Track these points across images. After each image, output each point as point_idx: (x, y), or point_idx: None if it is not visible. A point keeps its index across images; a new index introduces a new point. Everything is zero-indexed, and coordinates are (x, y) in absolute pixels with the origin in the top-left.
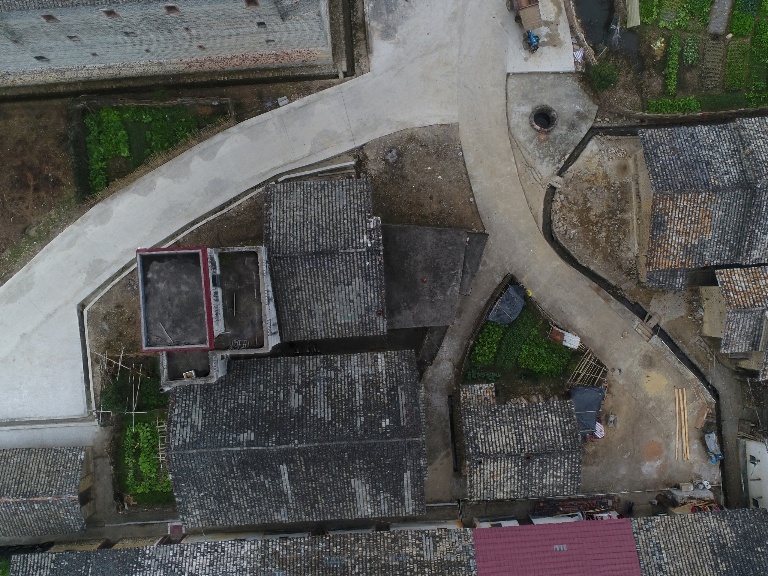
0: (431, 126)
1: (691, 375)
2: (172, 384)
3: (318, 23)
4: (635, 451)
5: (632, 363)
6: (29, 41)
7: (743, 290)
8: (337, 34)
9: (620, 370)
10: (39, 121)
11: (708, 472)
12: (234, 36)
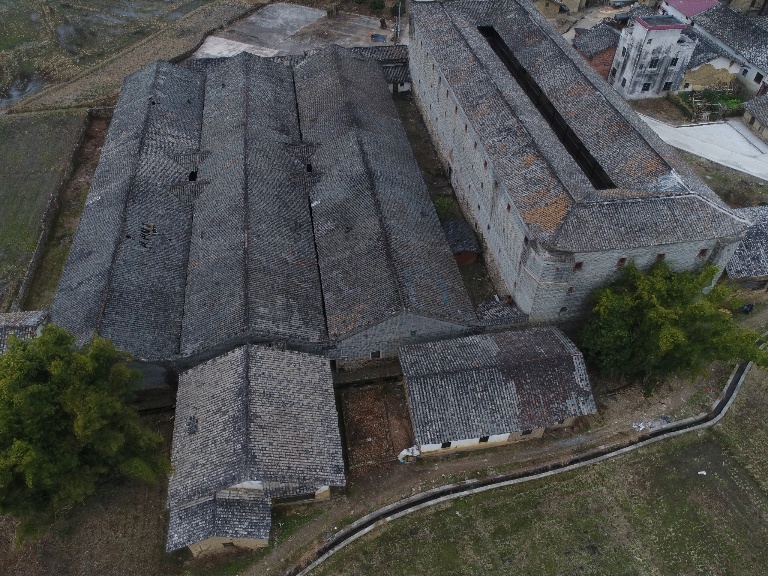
0: None
1: (594, 11)
2: None
3: None
4: None
5: None
6: None
7: None
8: None
9: None
10: None
11: (627, 8)
12: None
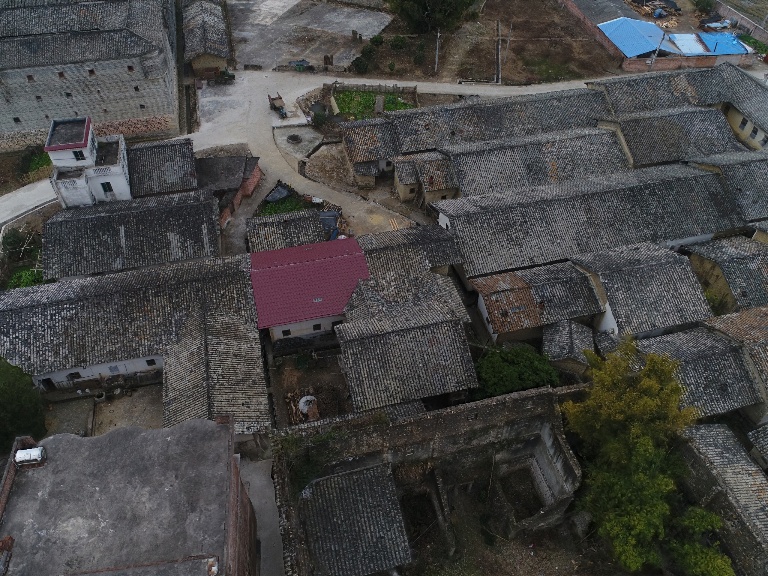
0: (232, 145)
1: (397, 214)
2: (57, 181)
3: (165, 89)
4: None
5: (360, 213)
6: (15, 101)
7: None
8: (183, 126)
9: (353, 216)
10: (4, 162)
11: None
12: (123, 100)
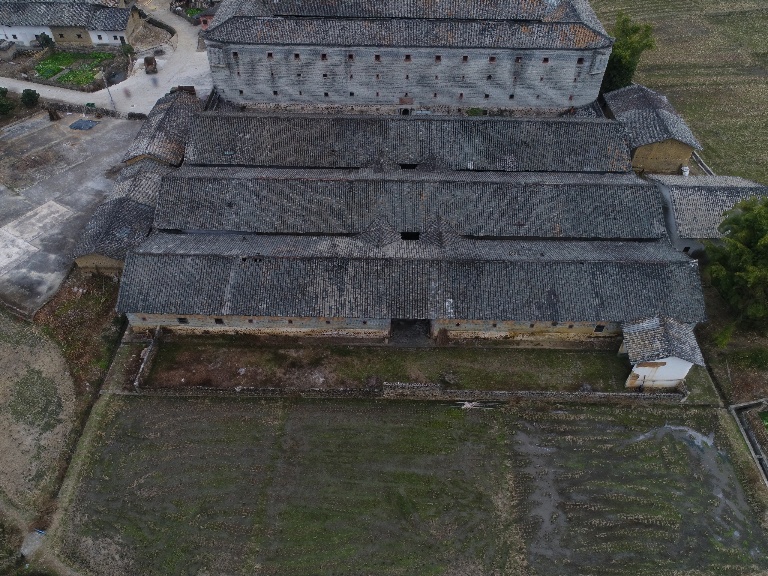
0: None
1: (139, 8)
2: None
3: None
4: None
5: None
6: None
7: (112, 1)
8: None
9: None
10: None
11: None
12: None
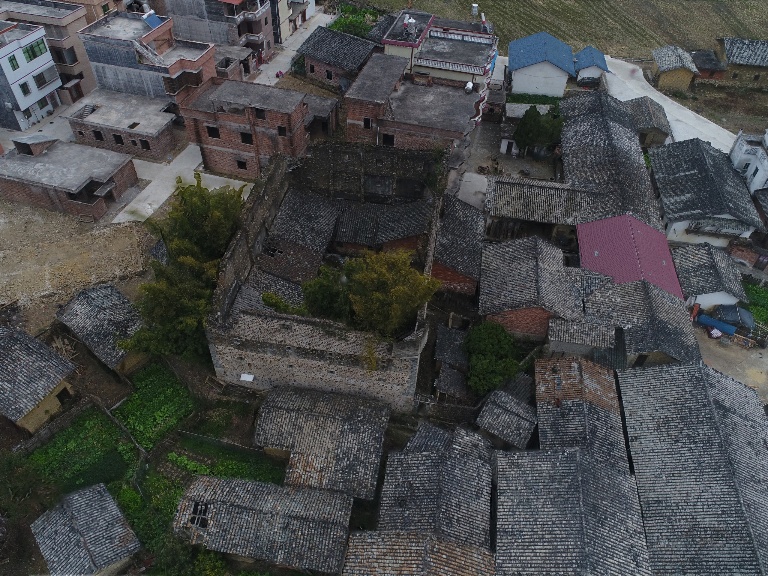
0: None
1: None
2: None
3: None
4: (702, 354)
5: None
6: None
7: None
8: None
9: (762, 358)
10: None
11: None
12: None
